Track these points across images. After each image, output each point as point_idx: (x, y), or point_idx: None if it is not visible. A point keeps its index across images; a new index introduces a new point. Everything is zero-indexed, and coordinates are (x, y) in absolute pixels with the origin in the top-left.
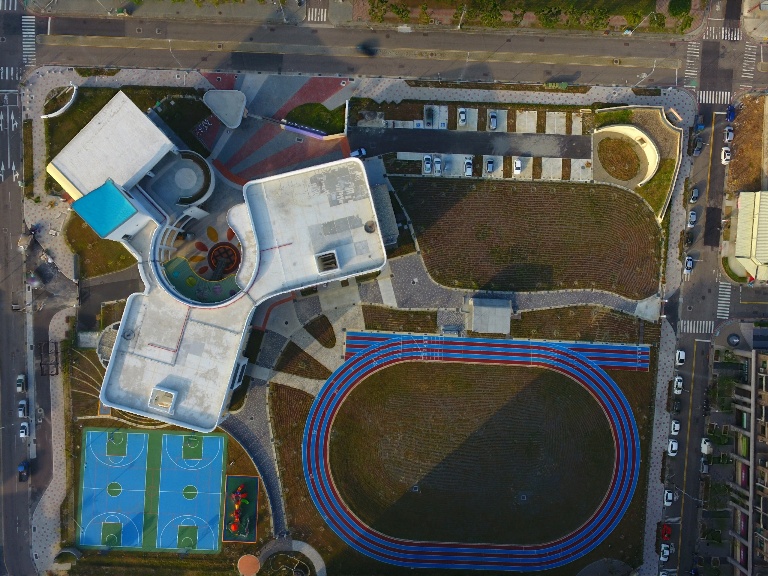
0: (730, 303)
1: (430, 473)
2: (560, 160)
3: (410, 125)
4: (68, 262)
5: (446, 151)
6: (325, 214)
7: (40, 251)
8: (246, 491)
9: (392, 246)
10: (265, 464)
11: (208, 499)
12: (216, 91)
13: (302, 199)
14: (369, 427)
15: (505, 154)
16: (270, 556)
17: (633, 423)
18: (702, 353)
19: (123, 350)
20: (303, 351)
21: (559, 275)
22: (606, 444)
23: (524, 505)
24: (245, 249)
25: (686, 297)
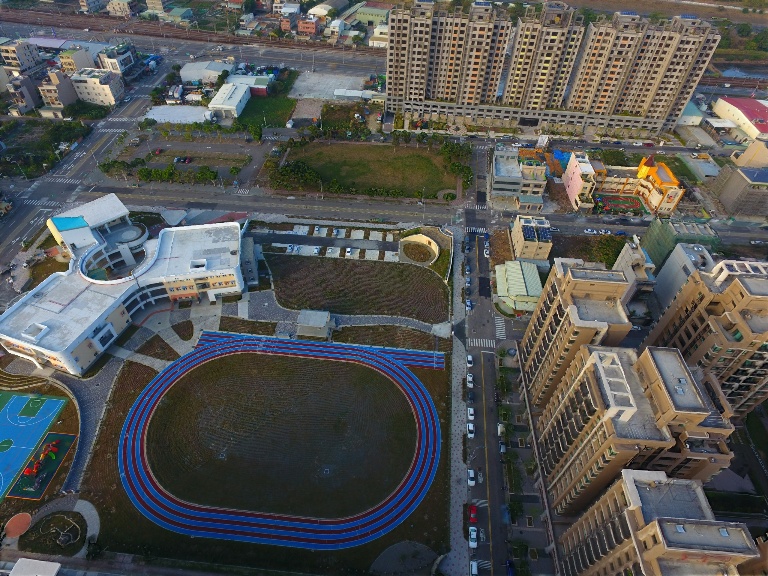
0: (505, 329)
1: (240, 442)
2: (378, 251)
3: (284, 233)
4: (23, 283)
5: (304, 244)
6: (208, 246)
7: (8, 277)
8: (59, 447)
9: (254, 285)
10: (89, 422)
11: (18, 453)
12: (170, 210)
13: (196, 239)
14: (197, 399)
15: (342, 247)
16: (46, 516)
17: (433, 408)
18: (488, 360)
19: (28, 303)
20: (164, 341)
21: (373, 307)
22: (409, 425)
23: (326, 478)
24: (147, 258)
25: (470, 324)
